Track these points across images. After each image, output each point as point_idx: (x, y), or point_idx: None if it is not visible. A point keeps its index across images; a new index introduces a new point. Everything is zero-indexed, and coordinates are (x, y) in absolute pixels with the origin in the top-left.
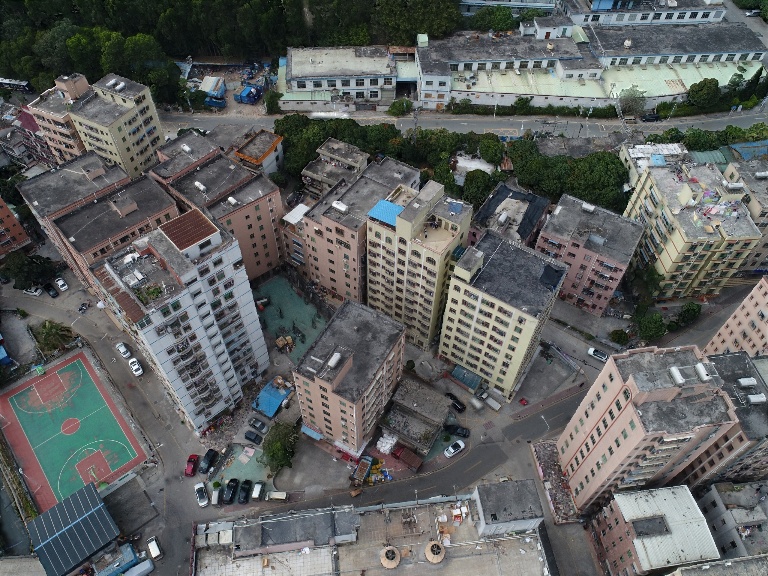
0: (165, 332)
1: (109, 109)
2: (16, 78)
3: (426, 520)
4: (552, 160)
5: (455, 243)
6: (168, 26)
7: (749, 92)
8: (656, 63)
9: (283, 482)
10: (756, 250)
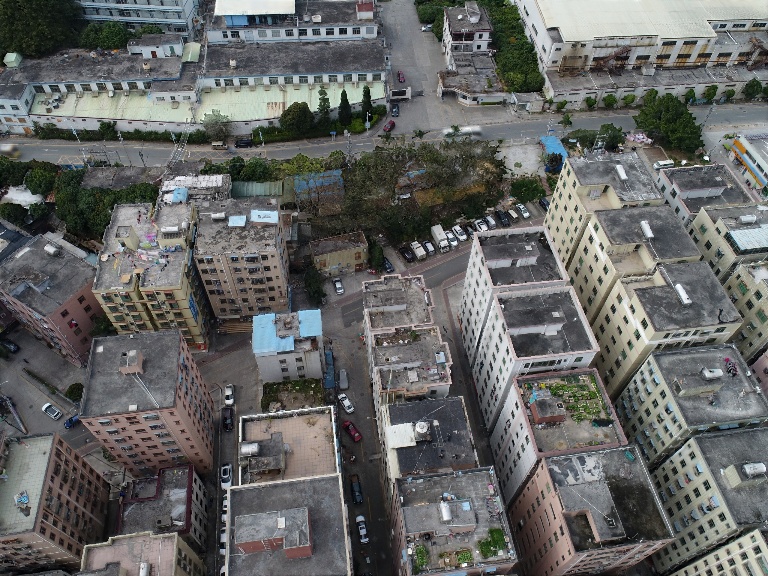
0: None
1: None
2: None
3: None
4: (80, 193)
5: None
6: None
7: (342, 116)
8: (267, 84)
9: None
10: (235, 296)
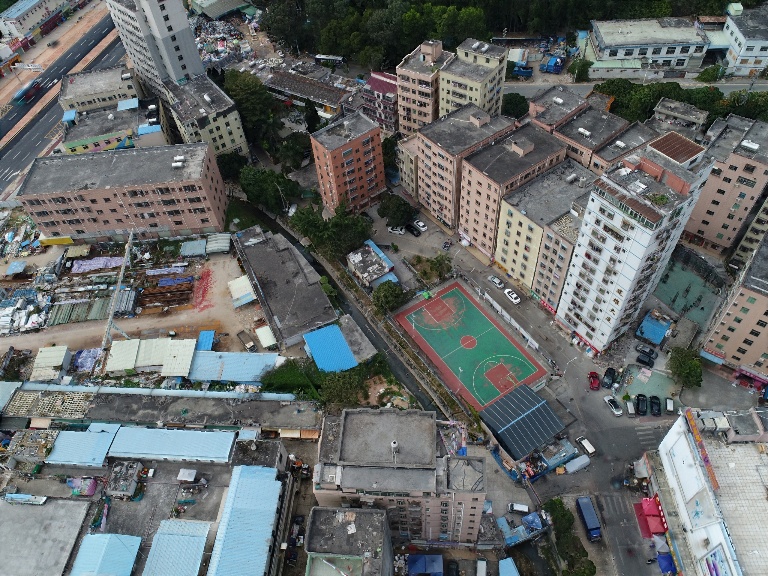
0: (661, 237)
1: (473, 69)
2: (334, 54)
3: None
4: None
5: None
6: (485, 2)
7: None
8: None
9: (689, 401)
10: None
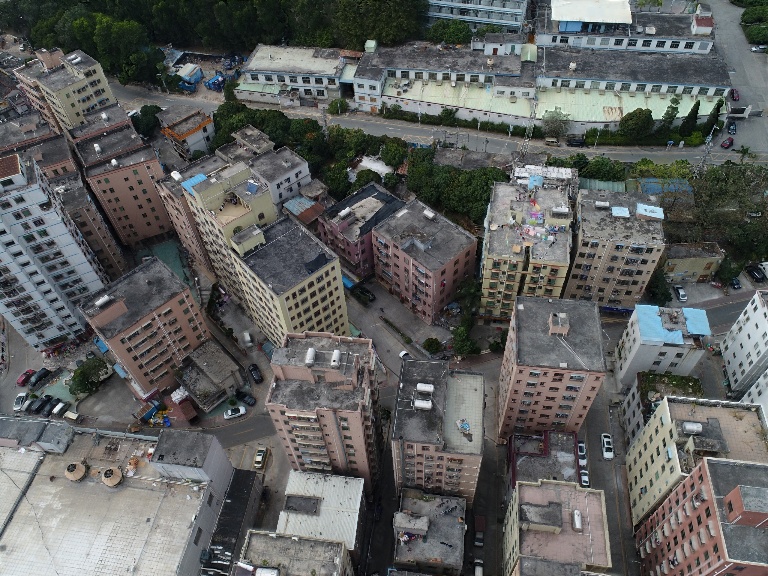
0: None
1: (66, 79)
2: None
3: (126, 451)
4: (437, 169)
5: (250, 221)
6: (159, 17)
7: (687, 127)
8: (602, 89)
9: (85, 407)
10: (595, 283)
